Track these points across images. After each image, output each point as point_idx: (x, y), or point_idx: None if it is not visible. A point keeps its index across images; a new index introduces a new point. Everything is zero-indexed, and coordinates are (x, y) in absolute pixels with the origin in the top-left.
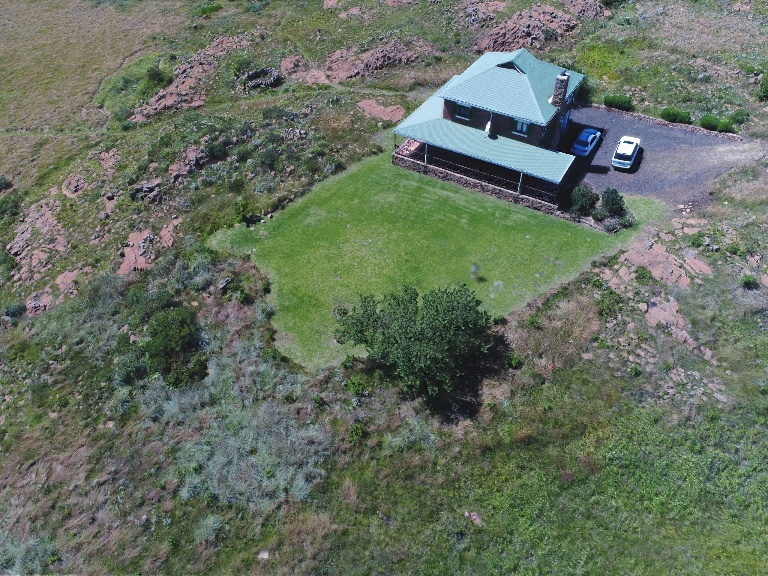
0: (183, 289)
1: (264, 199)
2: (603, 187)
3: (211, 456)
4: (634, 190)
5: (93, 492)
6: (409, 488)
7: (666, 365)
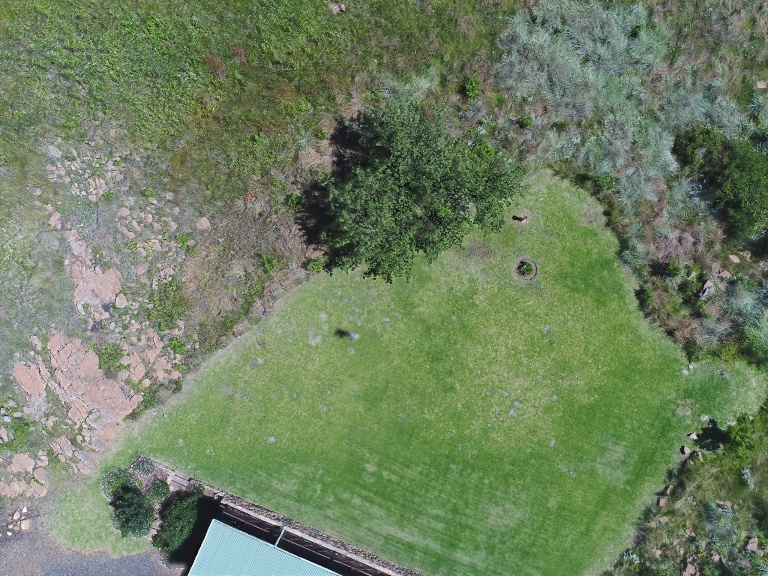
0: (762, 279)
1: (709, 486)
2: (143, 572)
3: (628, 49)
4: (93, 567)
5: (739, 5)
6: (405, 35)
7: (109, 196)
